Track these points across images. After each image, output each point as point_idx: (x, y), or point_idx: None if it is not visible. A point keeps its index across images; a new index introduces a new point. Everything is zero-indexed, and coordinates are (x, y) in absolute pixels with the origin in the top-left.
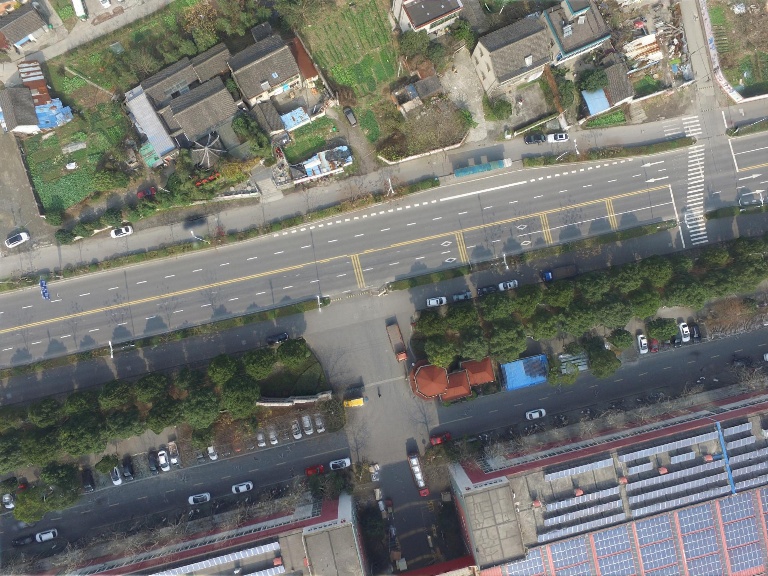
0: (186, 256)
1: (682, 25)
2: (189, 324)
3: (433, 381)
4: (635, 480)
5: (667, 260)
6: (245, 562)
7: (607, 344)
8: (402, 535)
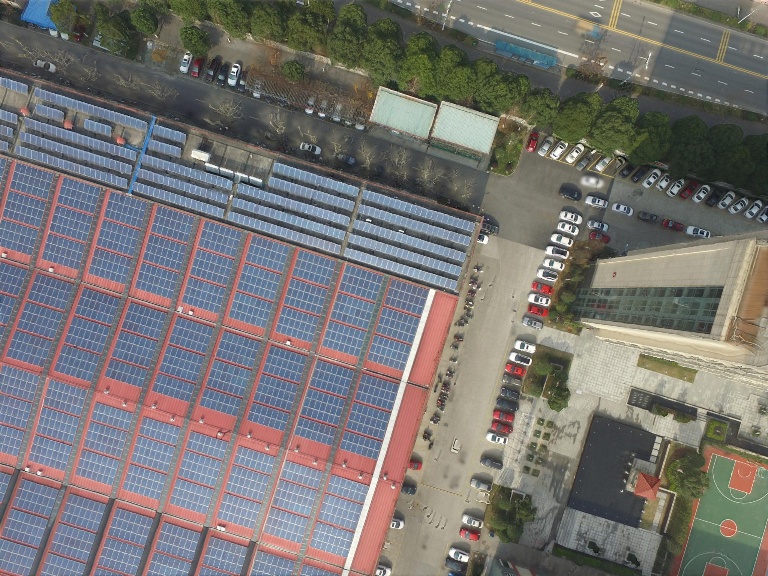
0: None
1: None
2: None
3: None
4: (39, 121)
5: None
6: None
7: (153, 43)
8: None
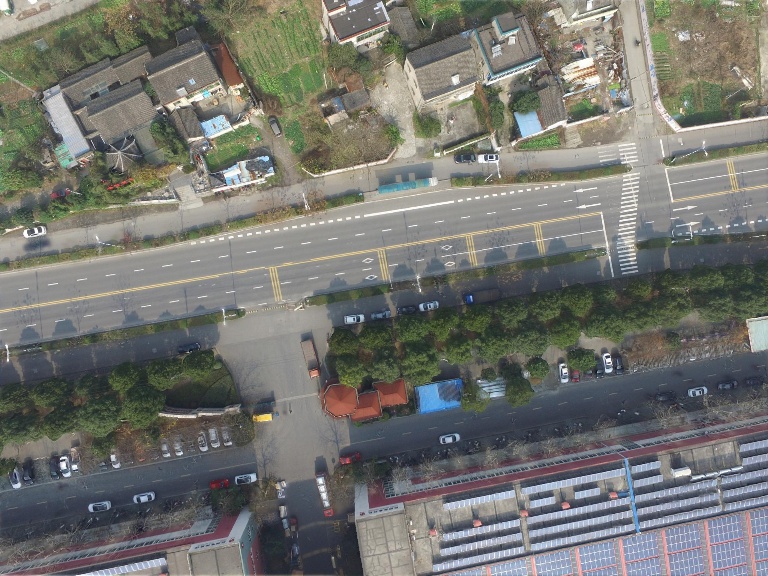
0: (100, 260)
1: (622, 50)
2: (99, 329)
3: (341, 401)
4: (537, 513)
5: (589, 290)
6: None
7: (527, 371)
8: (306, 554)
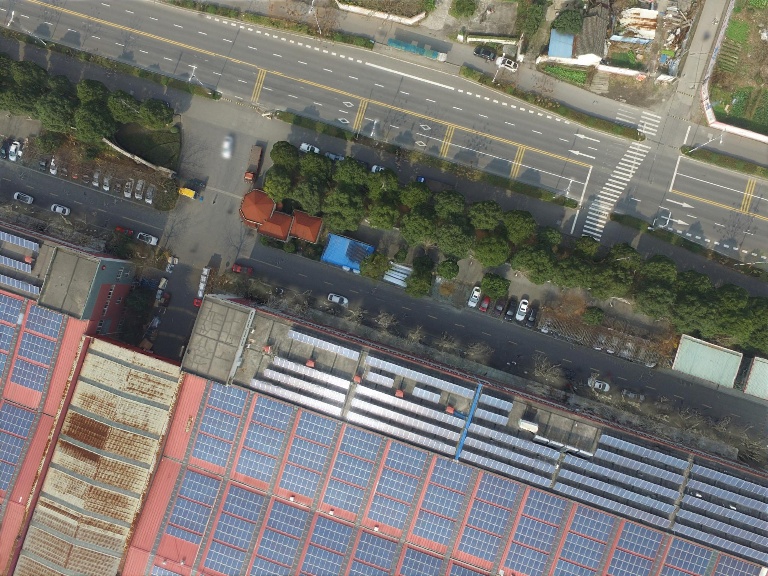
0: None
1: (693, 18)
2: (98, 52)
3: (255, 204)
4: (369, 387)
5: None
6: (6, 246)
7: (441, 277)
8: (163, 332)
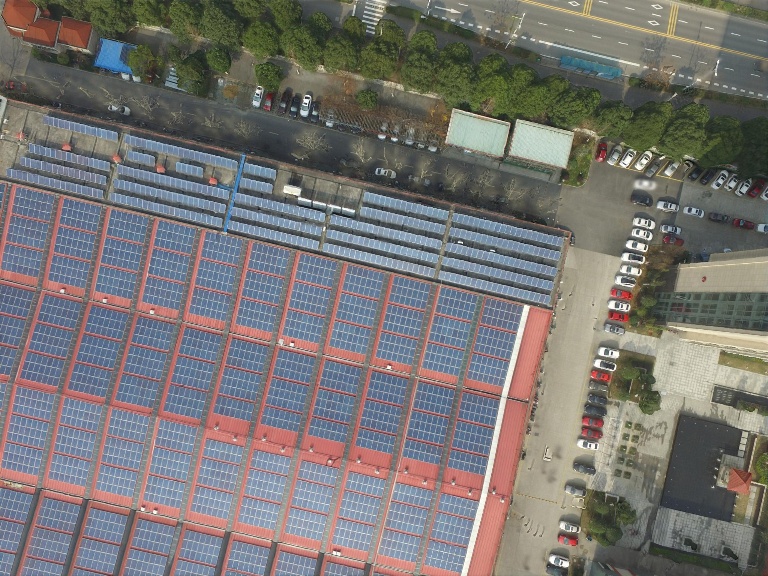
0: None
1: None
2: None
3: (14, 6)
4: (131, 167)
5: (300, 5)
6: None
7: (224, 80)
8: None
